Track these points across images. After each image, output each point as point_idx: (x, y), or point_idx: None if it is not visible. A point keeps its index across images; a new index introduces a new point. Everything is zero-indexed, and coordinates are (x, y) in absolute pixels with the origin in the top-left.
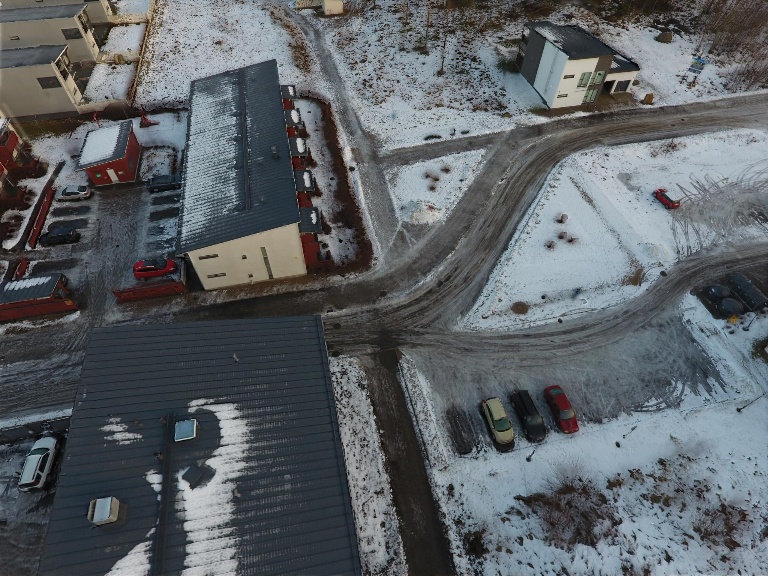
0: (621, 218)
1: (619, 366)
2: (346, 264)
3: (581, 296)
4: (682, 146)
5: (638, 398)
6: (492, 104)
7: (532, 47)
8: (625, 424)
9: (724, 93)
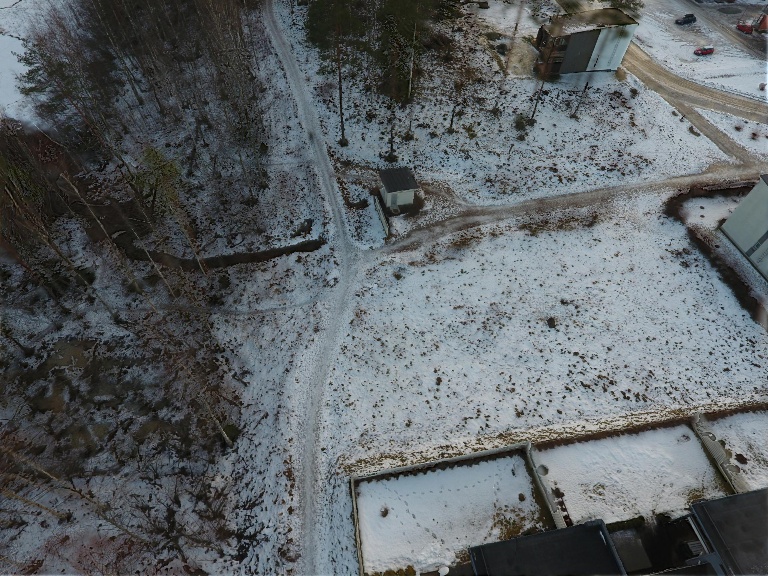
0: (740, 68)
1: None
2: None
3: None
4: (635, 35)
5: None
6: (614, 97)
7: (577, 46)
8: None
9: (555, 7)
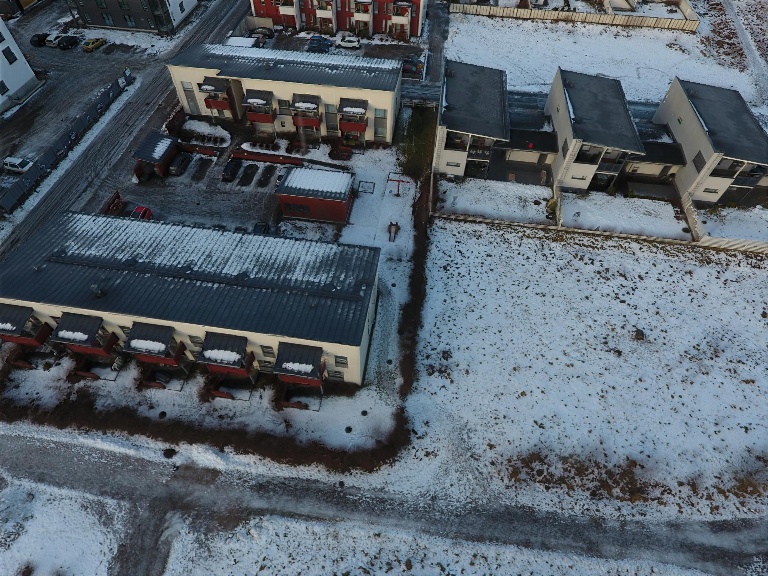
0: None
1: None
2: (7, 383)
3: None
4: None
5: None
6: None
7: None
8: None
9: None
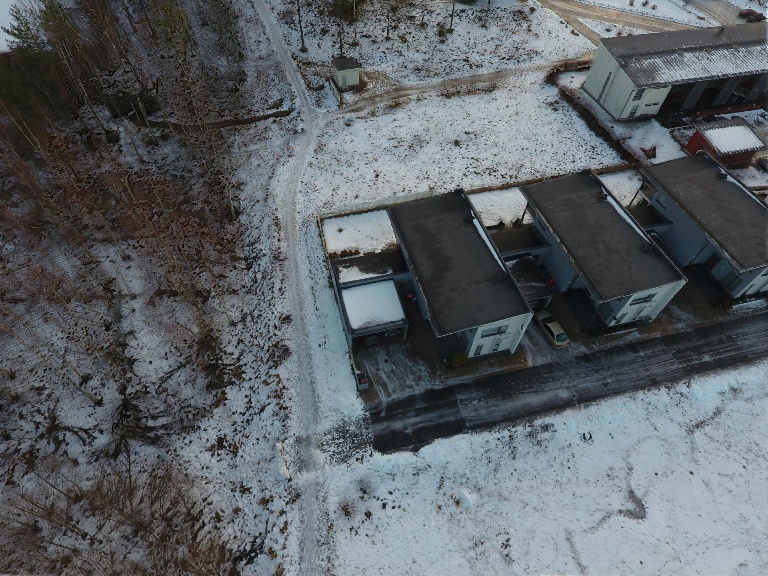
0: None
1: (713, 3)
2: None
3: (681, 5)
4: None
5: (725, 2)
6: (517, 14)
7: None
8: (740, 5)
9: None
